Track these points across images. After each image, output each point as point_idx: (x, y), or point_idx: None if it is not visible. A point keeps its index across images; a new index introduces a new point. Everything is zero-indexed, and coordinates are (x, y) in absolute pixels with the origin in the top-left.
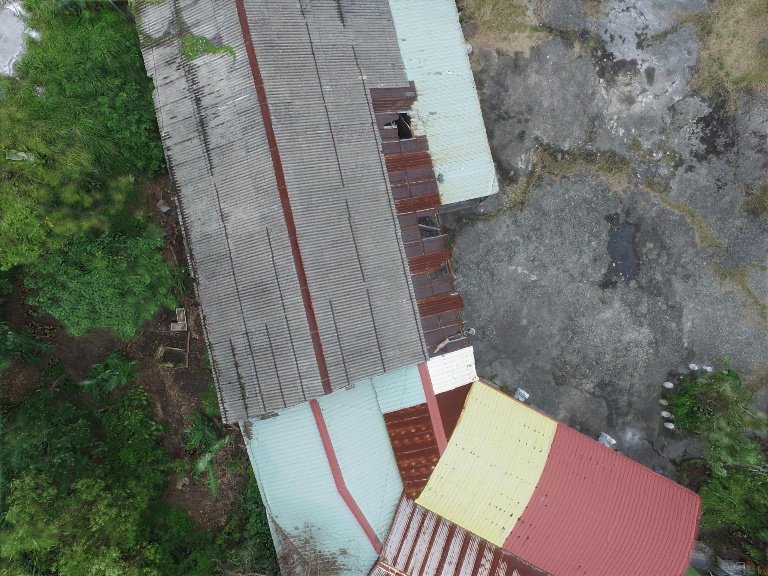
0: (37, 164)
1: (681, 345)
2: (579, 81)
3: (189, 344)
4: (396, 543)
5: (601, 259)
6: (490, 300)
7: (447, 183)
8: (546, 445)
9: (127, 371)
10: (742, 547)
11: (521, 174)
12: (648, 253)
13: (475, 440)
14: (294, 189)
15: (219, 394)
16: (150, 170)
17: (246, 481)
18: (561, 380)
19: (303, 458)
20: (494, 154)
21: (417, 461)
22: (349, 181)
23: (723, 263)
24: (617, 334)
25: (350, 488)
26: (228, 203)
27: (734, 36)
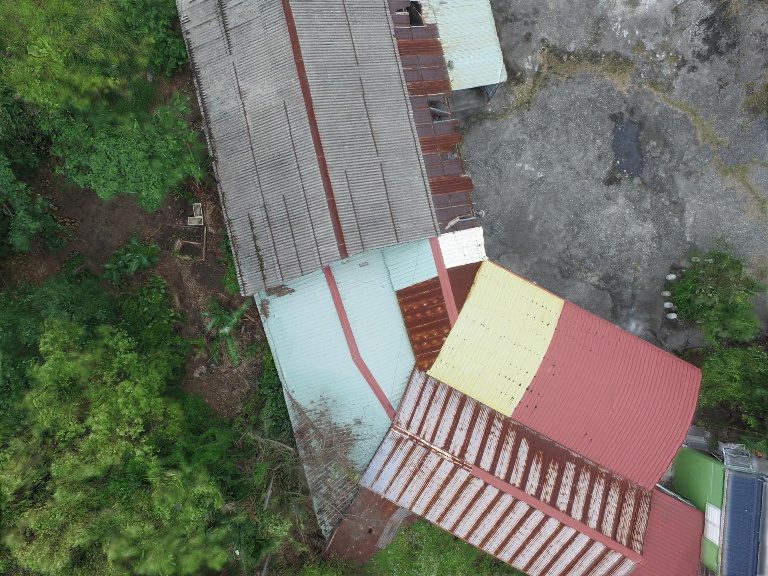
0: (58, 59)
1: (683, 239)
2: None
3: (205, 238)
4: (409, 409)
5: (606, 157)
6: (498, 196)
7: (457, 70)
8: (553, 319)
9: (147, 254)
10: (742, 419)
11: (528, 75)
12: (651, 151)
13: (485, 313)
14: (310, 63)
15: (237, 268)
16: (167, 67)
17: (261, 370)
18: (567, 273)
19: (319, 331)
20: None
21: (429, 334)
22: (363, 60)
23: (724, 160)
24: (621, 229)
25: (364, 358)
26: (246, 81)
27: None
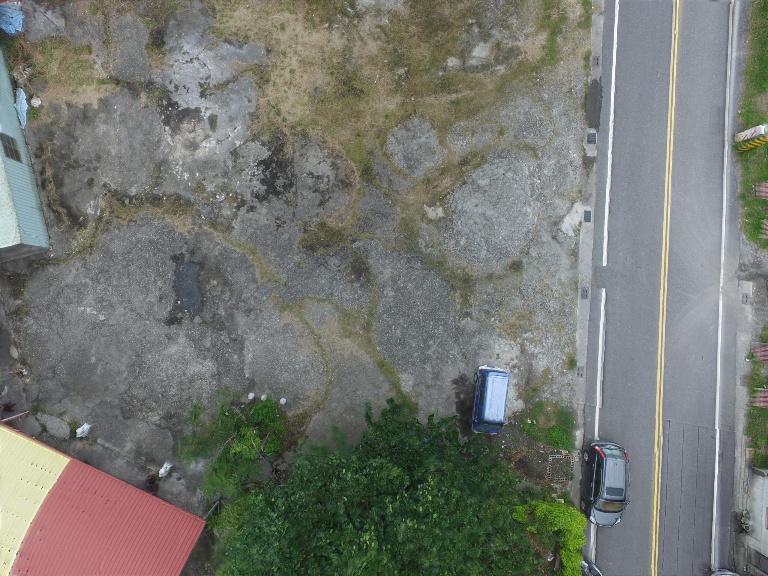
0: None
1: (242, 376)
2: (145, 129)
3: None
4: None
5: (167, 297)
6: (60, 340)
7: None
8: (49, 482)
9: None
10: None
11: (90, 219)
12: (211, 290)
13: None
14: None
15: None
16: None
17: None
18: (128, 414)
19: None
20: (64, 201)
21: None
22: None
23: (282, 297)
24: (182, 368)
25: None
26: None
27: (291, 83)
